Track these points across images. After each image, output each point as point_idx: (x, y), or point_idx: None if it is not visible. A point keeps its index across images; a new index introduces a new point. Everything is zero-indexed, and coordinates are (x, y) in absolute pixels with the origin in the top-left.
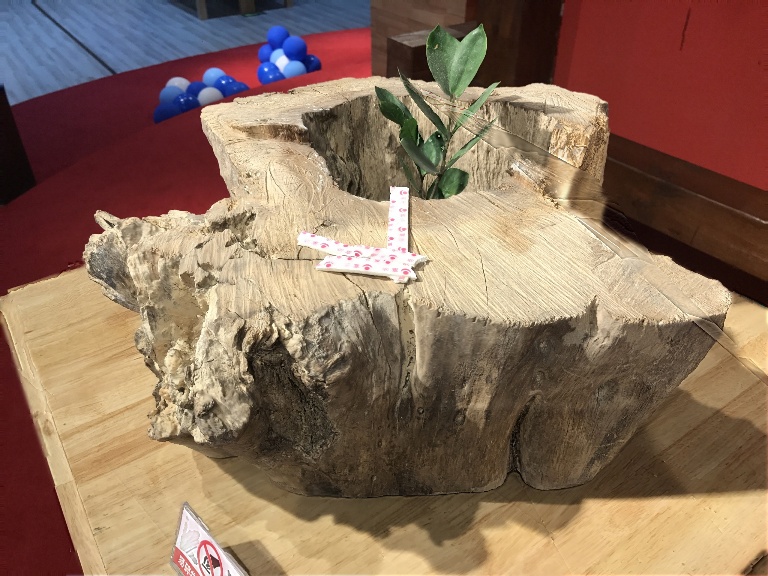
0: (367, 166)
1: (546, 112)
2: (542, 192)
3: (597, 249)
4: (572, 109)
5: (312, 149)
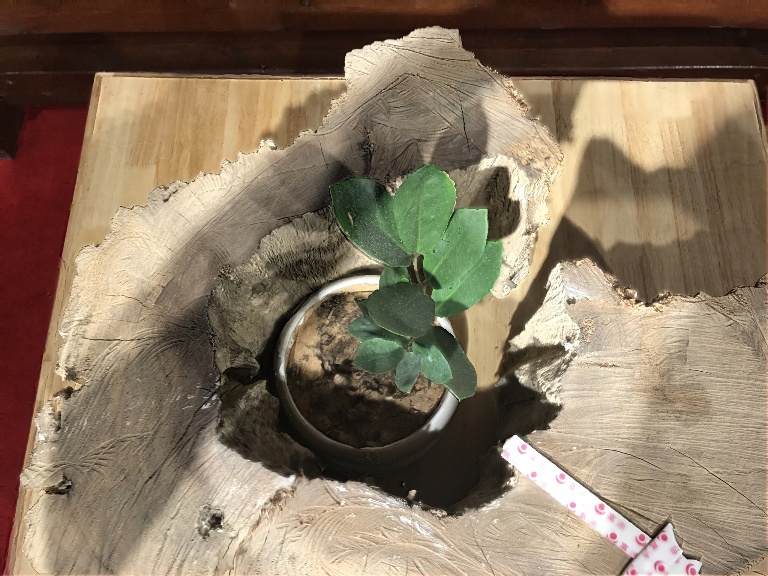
0: (243, 334)
1: (481, 150)
2: (630, 304)
3: (749, 339)
4: (476, 103)
5: (319, 483)
